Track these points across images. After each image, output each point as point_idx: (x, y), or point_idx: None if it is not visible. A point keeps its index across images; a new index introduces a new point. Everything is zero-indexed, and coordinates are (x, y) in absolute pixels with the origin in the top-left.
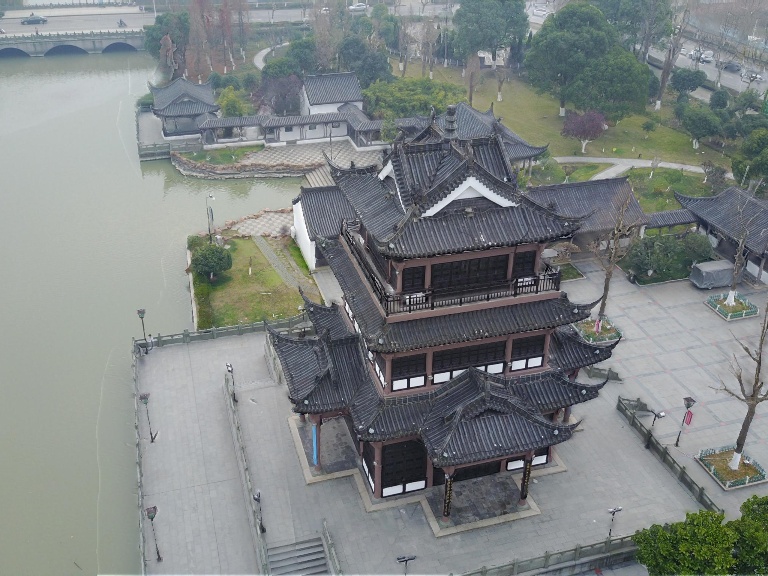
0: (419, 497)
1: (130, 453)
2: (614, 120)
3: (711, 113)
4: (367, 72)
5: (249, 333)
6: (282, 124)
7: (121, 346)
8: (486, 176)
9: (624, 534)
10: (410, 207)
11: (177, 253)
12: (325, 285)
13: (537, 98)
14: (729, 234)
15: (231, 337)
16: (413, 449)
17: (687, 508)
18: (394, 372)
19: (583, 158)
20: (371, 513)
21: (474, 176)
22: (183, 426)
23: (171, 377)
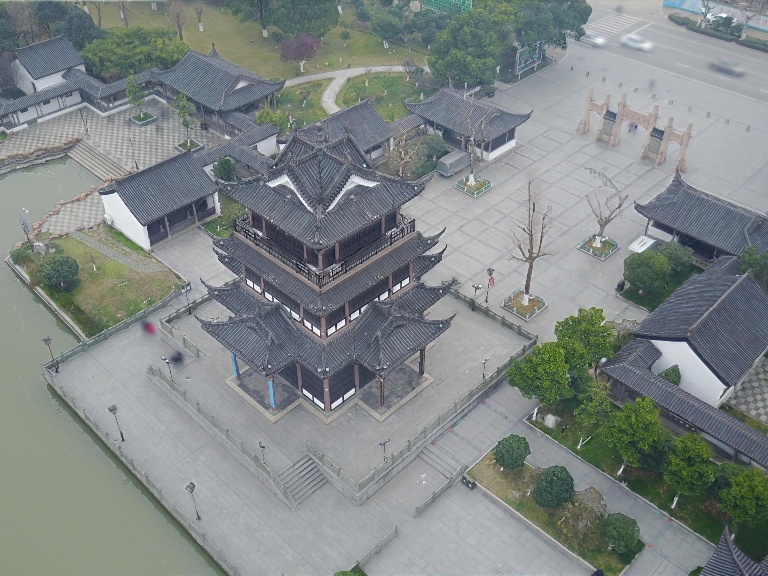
0: (355, 401)
1: (98, 457)
2: (318, 37)
3: (392, 17)
4: (76, 32)
5: (134, 324)
6: (19, 108)
7: (28, 374)
8: (359, 170)
9: (491, 373)
10: (316, 207)
11: (1, 270)
12: (169, 260)
13: (234, 21)
14: (454, 129)
15: (121, 332)
16: (346, 370)
17: (514, 342)
18: (327, 324)
19: (305, 78)
20: (330, 424)
21: (354, 174)
22: (139, 419)
23: (96, 384)
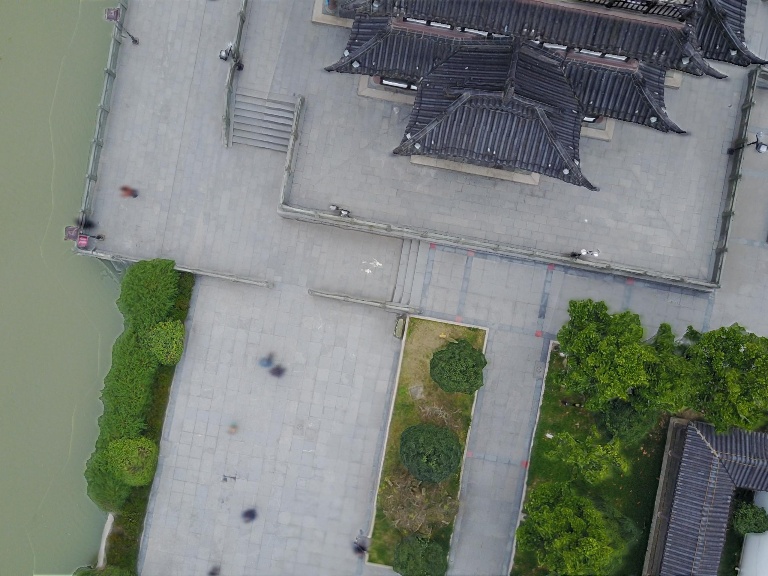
0: None
1: None
2: None
3: None
4: None
5: None
6: None
7: None
8: None
9: None
10: None
11: None
12: None
13: None
14: None
15: None
16: None
17: (696, 253)
18: None
19: None
20: (361, 97)
21: None
22: None
23: None
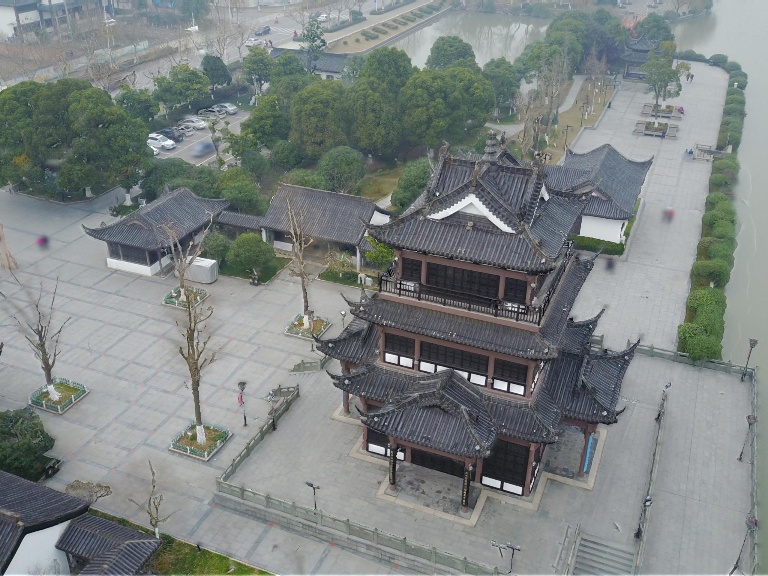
0: None
1: None
2: None
3: None
4: None
5: None
6: None
7: None
8: None
9: None
10: None
11: None
12: None
13: None
14: None
15: None
16: None
17: None
18: None
19: None
20: None
21: None
22: (699, 569)
23: None
